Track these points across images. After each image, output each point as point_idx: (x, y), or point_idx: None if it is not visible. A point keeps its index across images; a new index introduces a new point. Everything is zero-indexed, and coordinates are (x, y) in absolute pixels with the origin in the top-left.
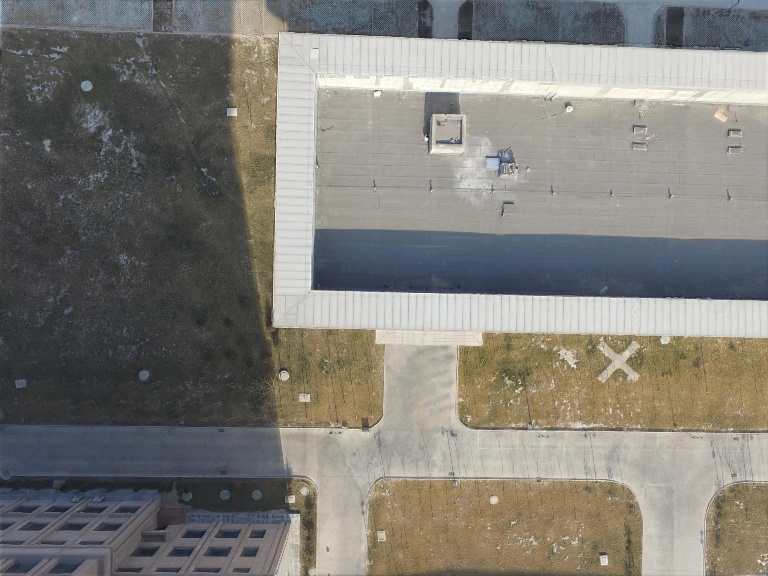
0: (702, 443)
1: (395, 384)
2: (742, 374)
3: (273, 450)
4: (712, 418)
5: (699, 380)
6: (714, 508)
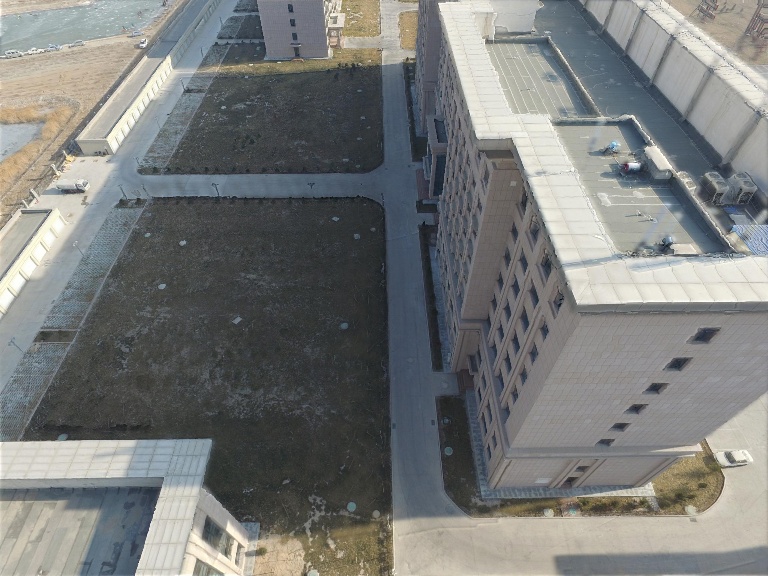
0: (384, 4)
1: (364, 46)
2: (361, 0)
3: (391, 66)
4: (375, 3)
5: (363, 5)
6: (406, 2)
